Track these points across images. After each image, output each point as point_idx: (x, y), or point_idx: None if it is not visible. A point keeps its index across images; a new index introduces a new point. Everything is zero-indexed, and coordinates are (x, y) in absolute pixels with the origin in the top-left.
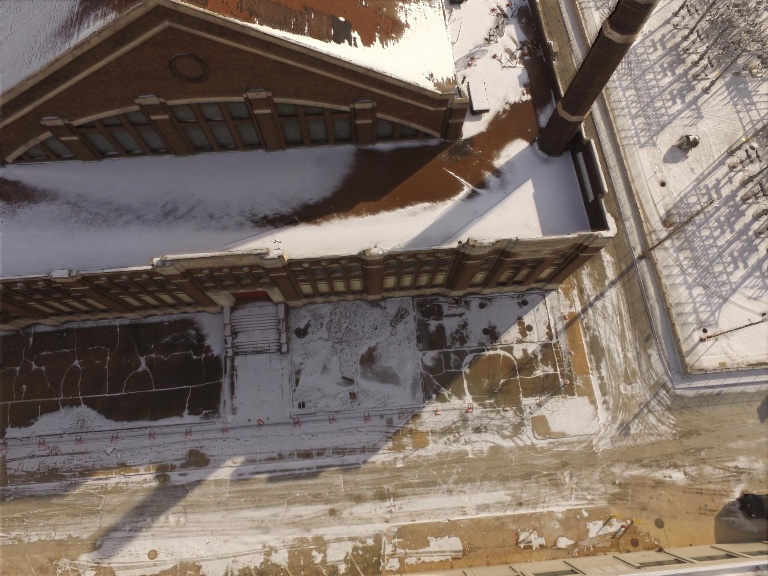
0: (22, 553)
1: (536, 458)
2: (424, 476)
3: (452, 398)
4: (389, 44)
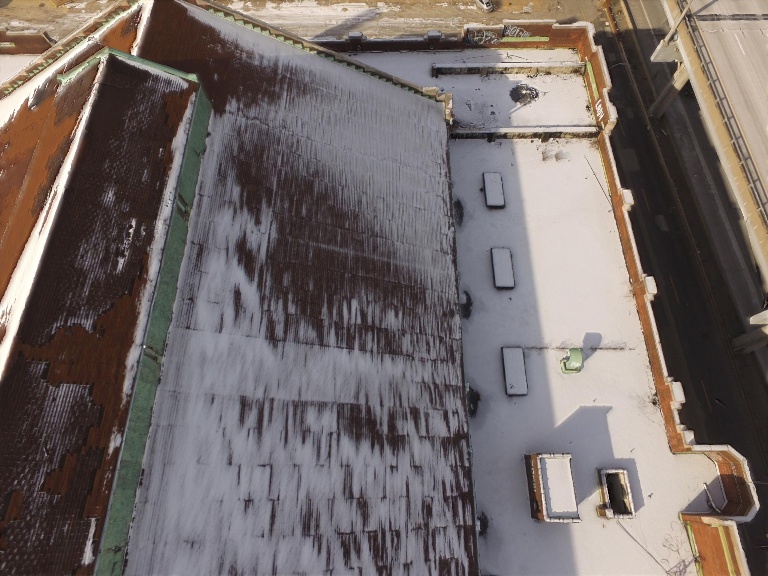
0: (422, 14)
1: None
2: None
3: None
4: (8, 119)
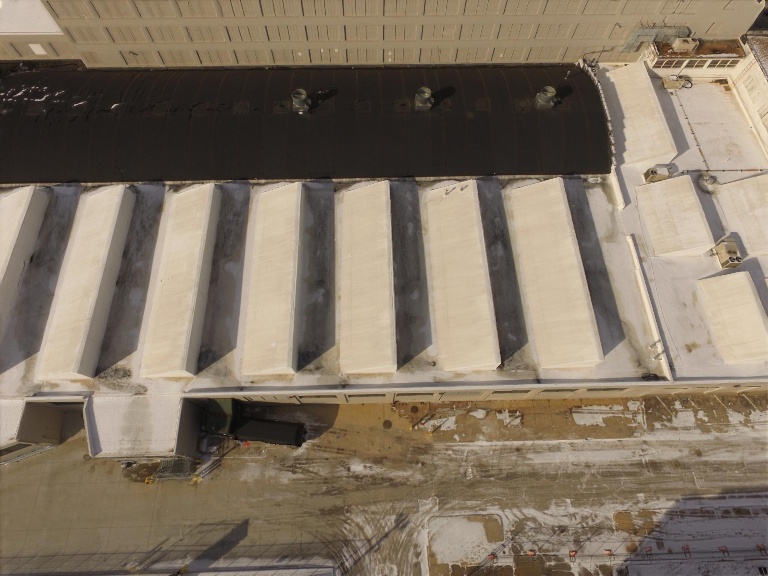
0: None
1: (500, 494)
2: (615, 483)
3: (594, 570)
4: None
